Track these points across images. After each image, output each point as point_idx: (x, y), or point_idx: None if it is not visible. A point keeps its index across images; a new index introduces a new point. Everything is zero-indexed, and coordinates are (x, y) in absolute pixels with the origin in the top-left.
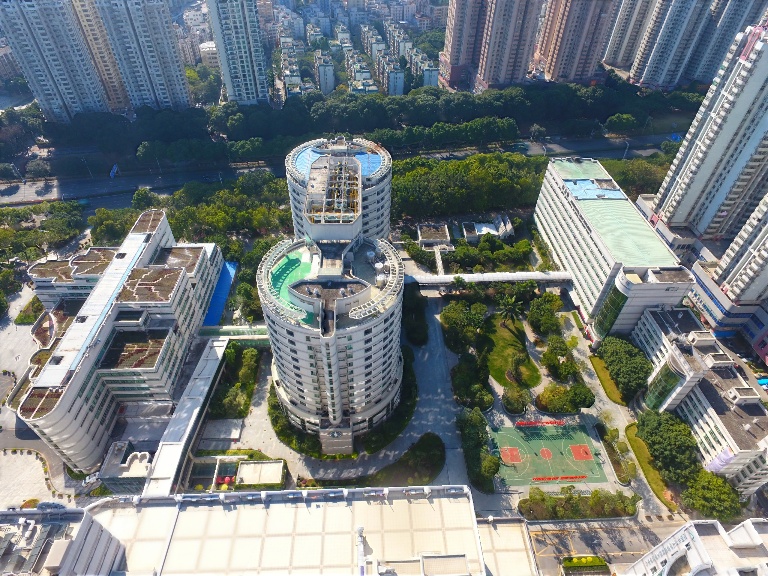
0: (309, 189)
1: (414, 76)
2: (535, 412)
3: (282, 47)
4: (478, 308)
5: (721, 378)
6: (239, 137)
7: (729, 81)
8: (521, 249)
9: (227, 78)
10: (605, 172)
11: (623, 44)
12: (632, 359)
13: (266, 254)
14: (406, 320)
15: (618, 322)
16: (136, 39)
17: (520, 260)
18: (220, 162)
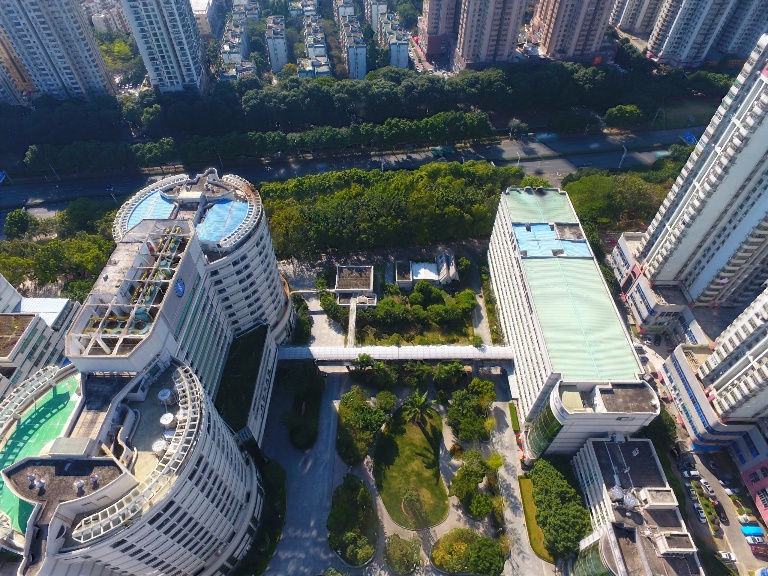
0: (98, 284)
1: (379, 51)
2: (428, 569)
3: (232, 12)
4: (383, 400)
5: (675, 573)
6: (157, 133)
7: (744, 105)
8: (461, 305)
9: (146, 59)
10: (572, 211)
11: (643, 6)
12: (564, 507)
13: (10, 395)
14: (286, 417)
15: (554, 445)
16: (24, 14)
17: (457, 320)
18: (129, 167)
